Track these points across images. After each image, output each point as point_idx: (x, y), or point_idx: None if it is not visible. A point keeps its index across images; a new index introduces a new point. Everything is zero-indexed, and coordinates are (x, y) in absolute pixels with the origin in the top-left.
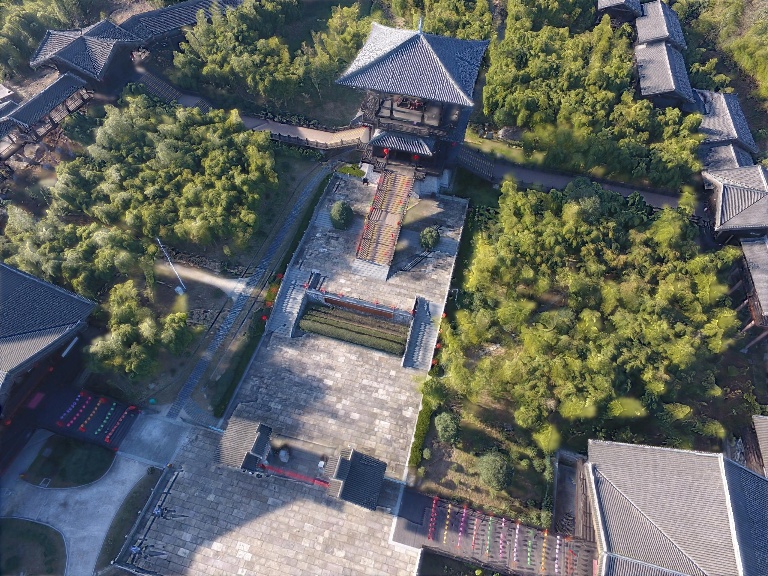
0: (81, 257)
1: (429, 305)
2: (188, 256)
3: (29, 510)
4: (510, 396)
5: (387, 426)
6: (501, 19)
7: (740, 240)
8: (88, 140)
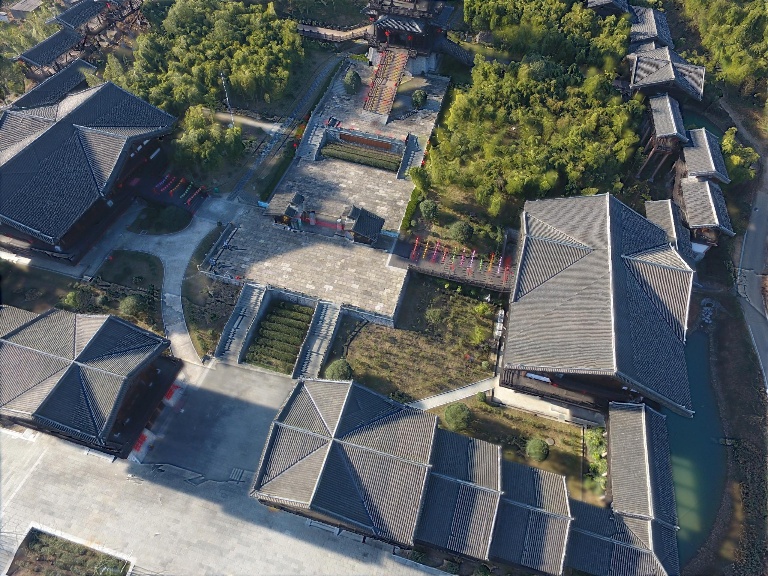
0: (162, 91)
1: (417, 139)
2: (235, 109)
3: (135, 246)
4: (475, 197)
5: (385, 209)
6: None
7: (649, 98)
8: (160, 20)
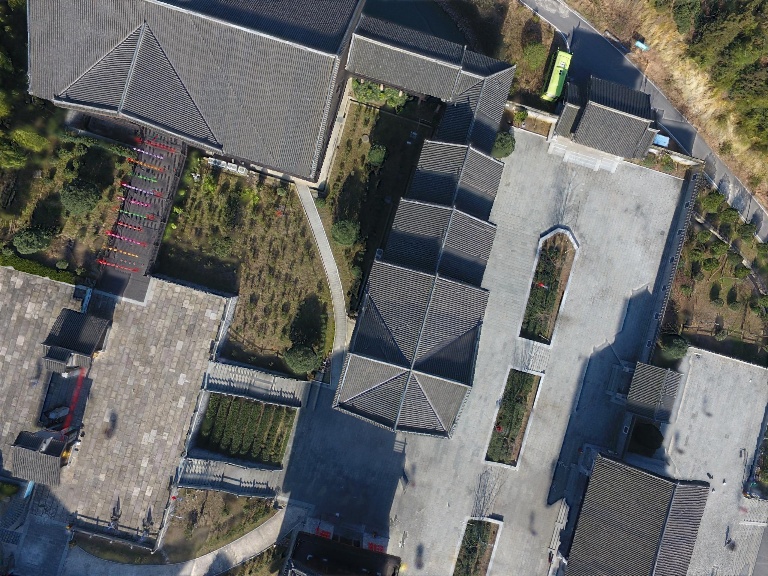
0: None
1: None
2: None
3: None
4: None
5: (32, 306)
6: None
7: None
8: None
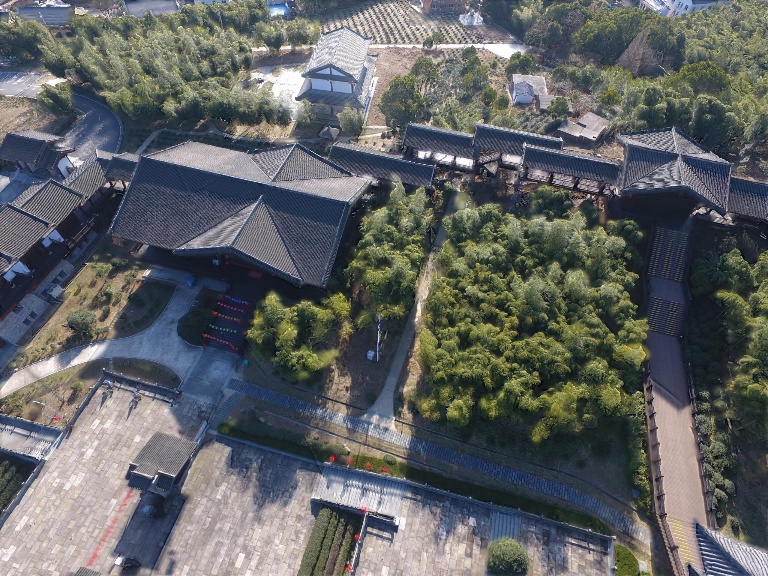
0: (378, 258)
1: None
2: None
3: (177, 300)
4: None
5: None
6: None
7: None
8: (533, 215)
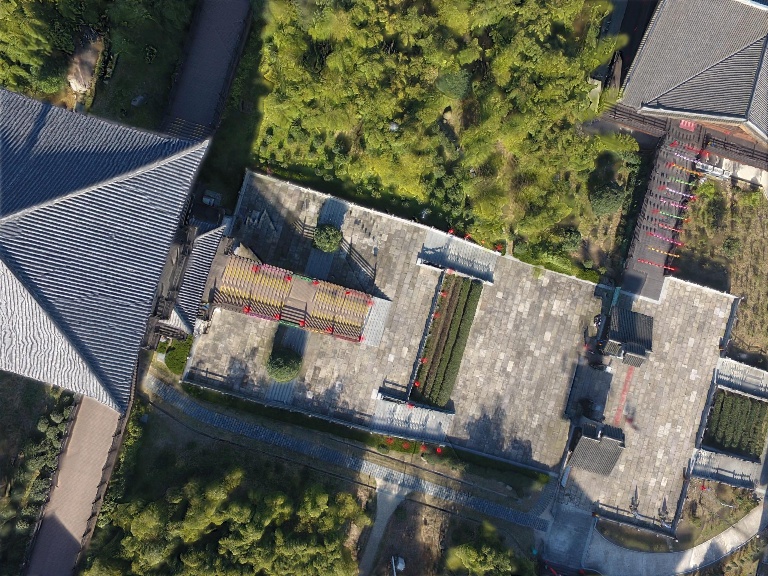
0: None
1: (428, 248)
2: None
3: None
4: None
5: (558, 303)
6: None
7: None
8: None
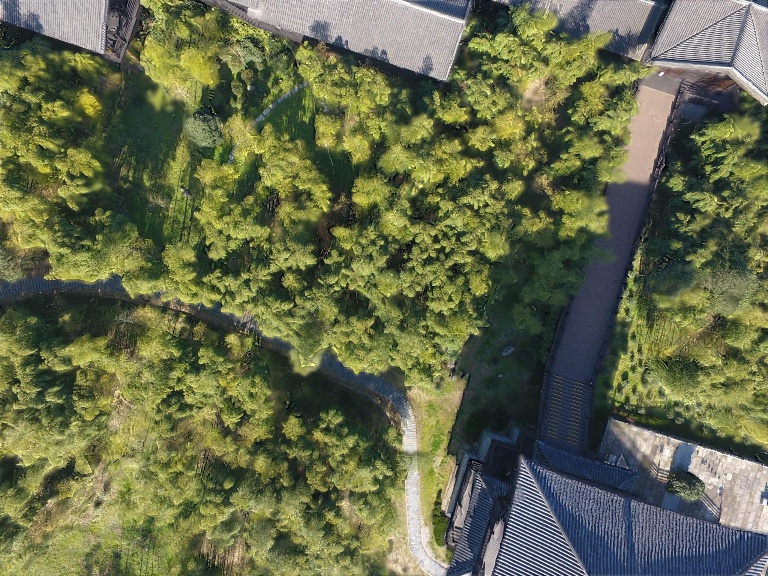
0: None
1: None
2: None
3: None
4: None
5: None
6: (142, 308)
7: None
8: None
